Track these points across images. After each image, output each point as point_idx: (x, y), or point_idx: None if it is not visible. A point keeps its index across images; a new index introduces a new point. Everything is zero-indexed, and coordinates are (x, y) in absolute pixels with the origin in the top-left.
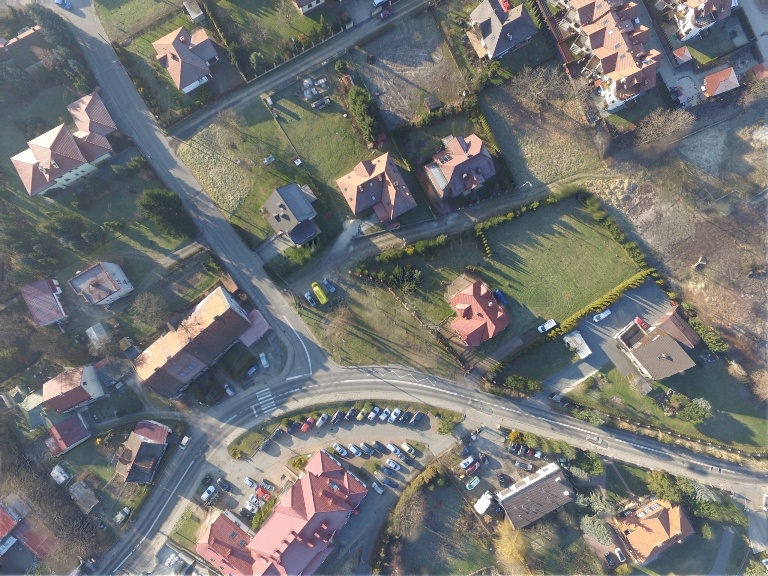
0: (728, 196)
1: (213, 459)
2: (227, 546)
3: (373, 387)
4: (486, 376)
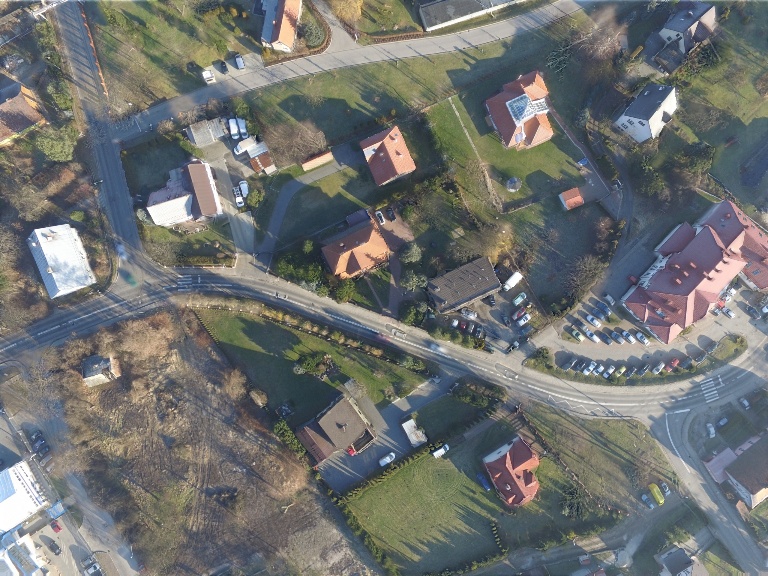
0: (253, 573)
1: (761, 337)
2: (765, 265)
3: (608, 398)
4: (503, 405)
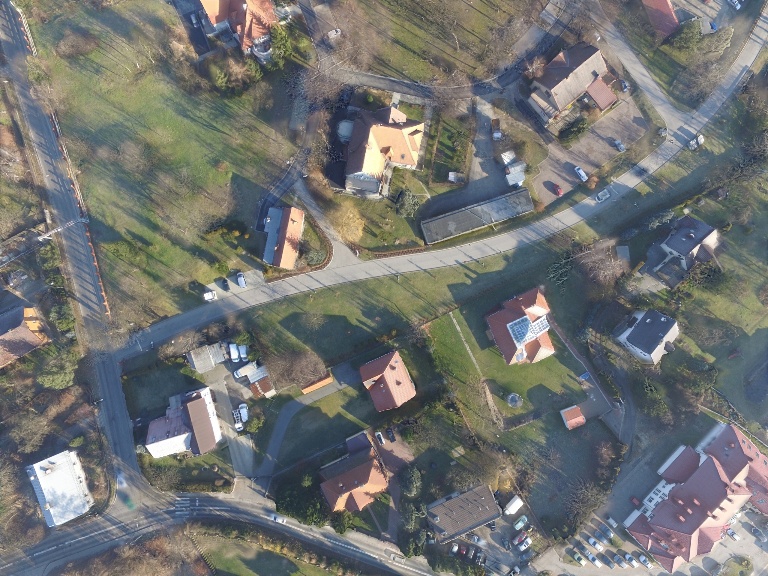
0: None
1: (767, 559)
2: None
3: None
4: None
